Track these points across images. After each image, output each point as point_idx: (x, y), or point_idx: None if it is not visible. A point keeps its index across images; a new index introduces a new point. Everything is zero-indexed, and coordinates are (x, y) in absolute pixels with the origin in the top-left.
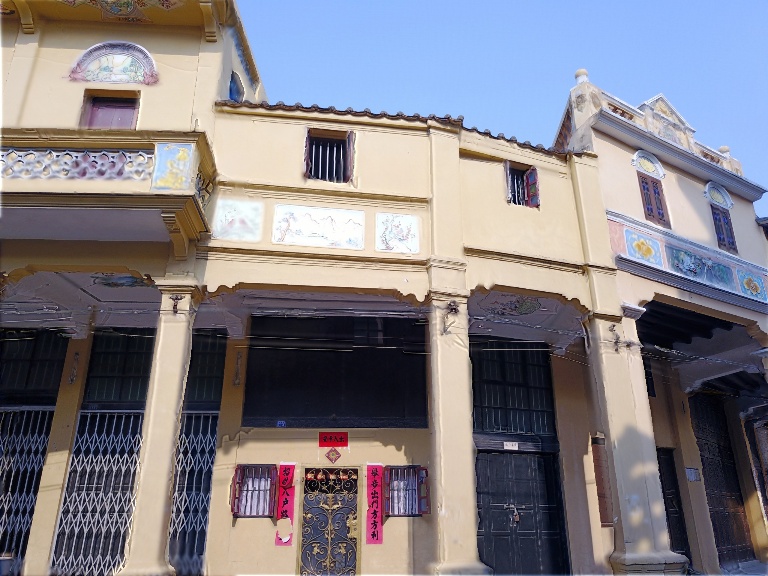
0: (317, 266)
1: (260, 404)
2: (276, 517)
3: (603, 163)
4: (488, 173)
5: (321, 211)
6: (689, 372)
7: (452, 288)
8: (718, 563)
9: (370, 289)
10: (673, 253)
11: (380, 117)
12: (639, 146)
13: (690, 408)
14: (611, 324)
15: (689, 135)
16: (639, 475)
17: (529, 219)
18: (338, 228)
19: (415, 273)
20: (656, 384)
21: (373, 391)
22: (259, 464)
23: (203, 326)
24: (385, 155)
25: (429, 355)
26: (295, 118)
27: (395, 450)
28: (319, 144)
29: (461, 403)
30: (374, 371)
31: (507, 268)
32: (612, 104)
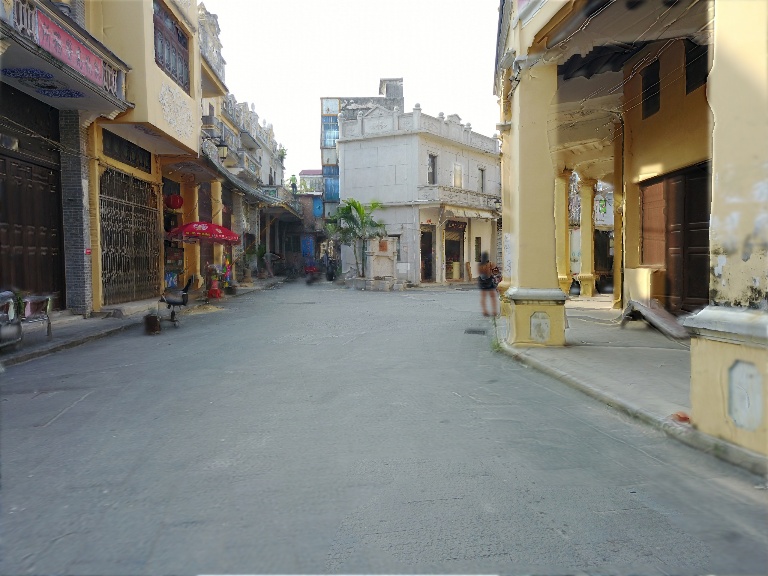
0: None
1: None
2: None
3: None
4: None
5: None
6: None
7: None
8: None
9: None
10: None
11: None
12: None
13: None
14: None
15: None
16: None
17: None
18: None
19: None
20: (710, 58)
21: None
22: None
23: None
24: None
25: None
26: None
27: None
28: None
29: None
30: None
31: None
32: None
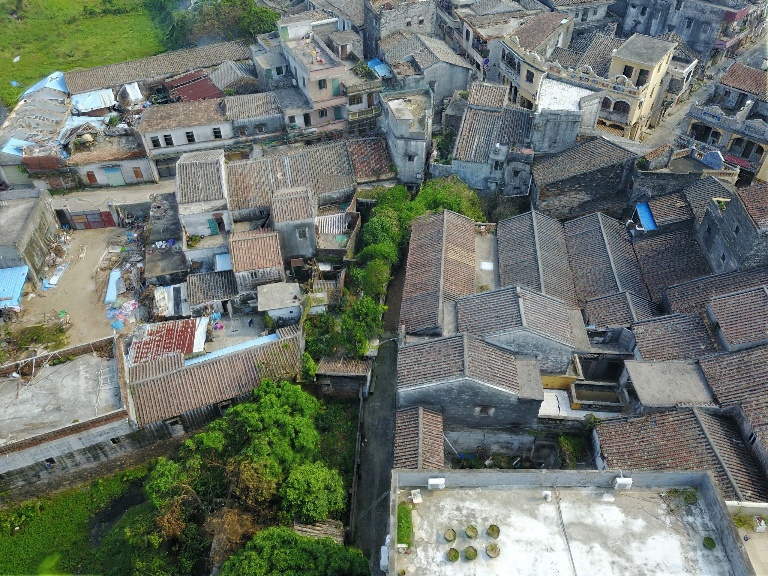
0: None
1: None
2: None
3: None
4: None
5: None
6: None
7: None
8: None
9: None
10: None
11: None
12: None
13: None
14: None
15: None
16: None
17: None
18: None
19: None
20: None
21: None
22: None
23: None
24: None
25: None
26: None
27: None
28: None
29: None
30: None
31: None
32: None
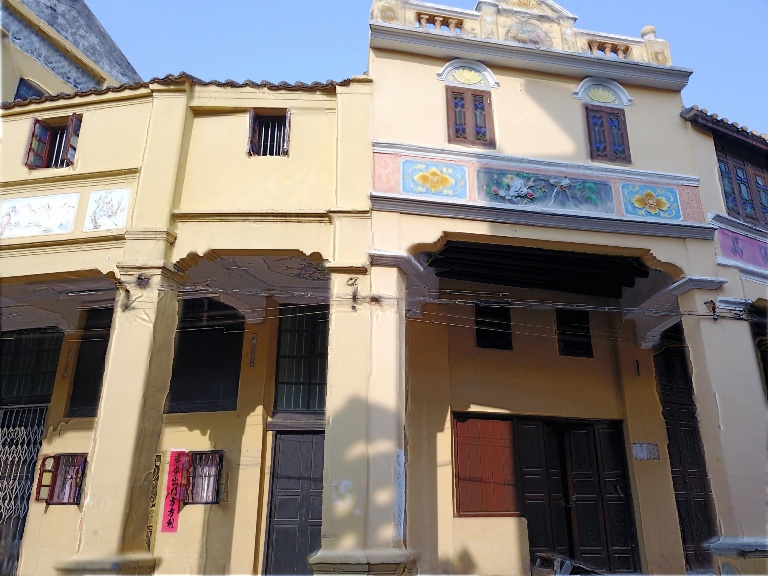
0: (27, 255)
1: (85, 395)
2: (82, 504)
3: (383, 87)
4: (230, 127)
5: (40, 200)
6: (642, 323)
7: (143, 260)
8: (684, 564)
9: (74, 272)
10: (492, 179)
11: (105, 92)
12: (451, 55)
13: (668, 368)
14: (349, 277)
15: (565, 25)
16: (357, 456)
17: (273, 169)
18: (52, 214)
19: (118, 249)
20: (596, 341)
21: (190, 375)
22: (75, 453)
23: (50, 324)
24: (108, 130)
25: (245, 332)
26: (31, 112)
27: (200, 435)
28: (63, 132)
29: (133, 383)
30: (193, 354)
31: (230, 229)
32: (424, 13)
